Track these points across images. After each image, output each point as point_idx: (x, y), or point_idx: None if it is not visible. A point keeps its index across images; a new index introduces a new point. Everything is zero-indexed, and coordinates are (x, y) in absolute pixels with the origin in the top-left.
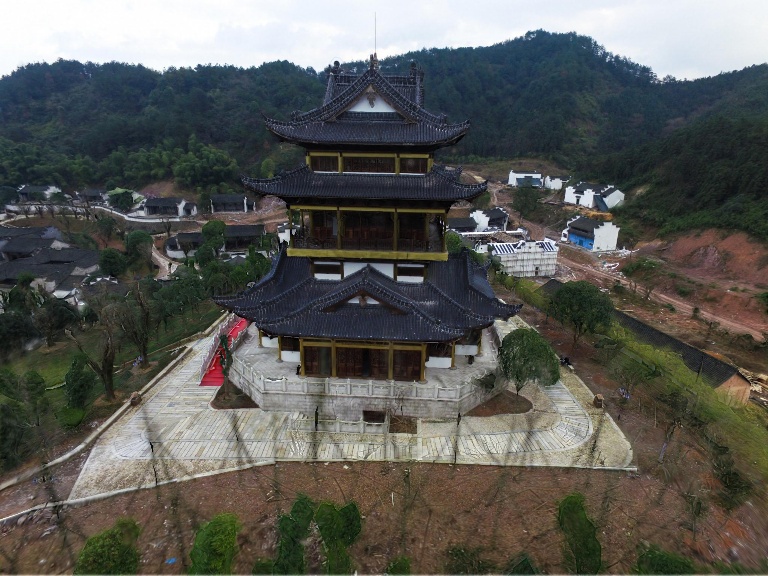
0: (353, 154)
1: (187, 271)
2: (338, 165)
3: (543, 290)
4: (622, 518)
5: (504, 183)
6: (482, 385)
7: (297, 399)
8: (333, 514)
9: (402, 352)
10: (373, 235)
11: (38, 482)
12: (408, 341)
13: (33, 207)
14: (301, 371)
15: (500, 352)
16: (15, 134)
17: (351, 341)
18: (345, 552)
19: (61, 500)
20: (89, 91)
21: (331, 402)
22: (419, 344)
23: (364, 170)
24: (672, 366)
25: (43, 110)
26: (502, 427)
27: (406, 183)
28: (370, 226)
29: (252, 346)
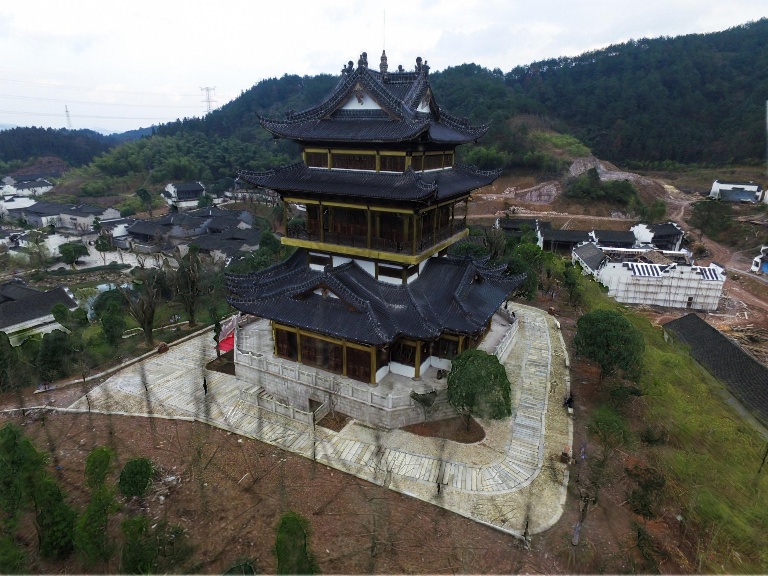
0: (339, 151)
1: (267, 253)
2: (328, 161)
3: (675, 325)
4: None
5: (703, 195)
6: (416, 400)
7: (259, 374)
8: (96, 459)
9: (354, 350)
10: (358, 232)
11: (42, 388)
12: (347, 339)
13: (240, 194)
14: (275, 351)
15: (451, 370)
16: (244, 136)
17: (308, 330)
18: (112, 497)
19: (64, 407)
20: (301, 100)
21: (284, 384)
22: (367, 345)
23: (350, 167)
24: (729, 443)
25: (266, 116)
26: (427, 450)
27: (381, 181)
28: (356, 222)
29: (265, 323)
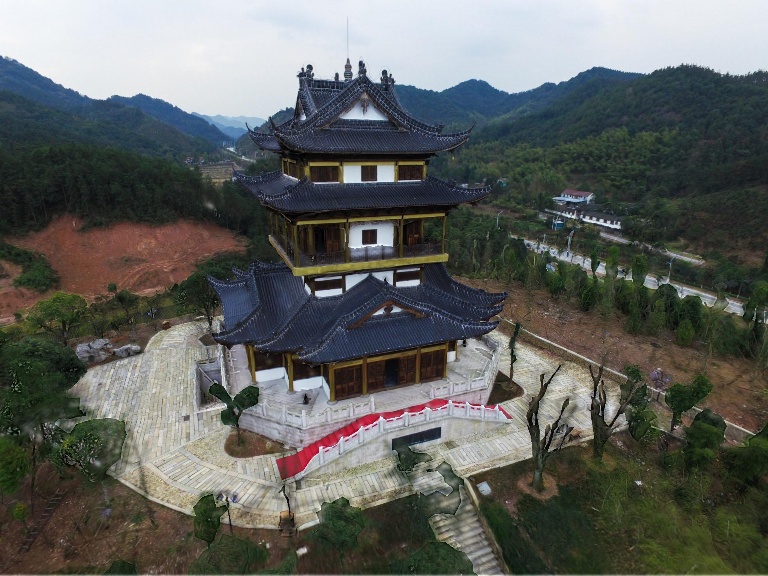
0: None
1: None
2: None
3: None
4: (462, 280)
5: None
6: None
7: None
8: None
9: None
10: None
11: None
12: None
13: None
14: None
15: None
16: None
17: None
18: None
19: (652, 405)
20: None
21: None
22: None
23: None
24: None
25: None
26: None
27: None
28: None
29: None
